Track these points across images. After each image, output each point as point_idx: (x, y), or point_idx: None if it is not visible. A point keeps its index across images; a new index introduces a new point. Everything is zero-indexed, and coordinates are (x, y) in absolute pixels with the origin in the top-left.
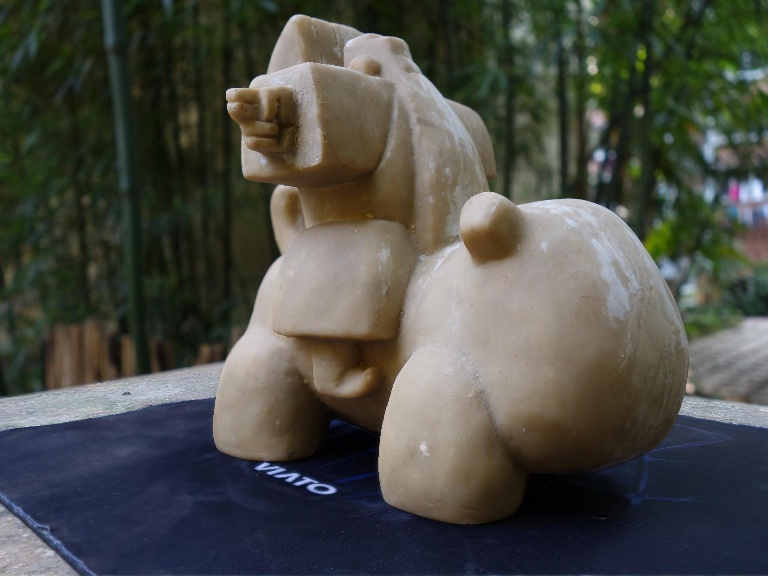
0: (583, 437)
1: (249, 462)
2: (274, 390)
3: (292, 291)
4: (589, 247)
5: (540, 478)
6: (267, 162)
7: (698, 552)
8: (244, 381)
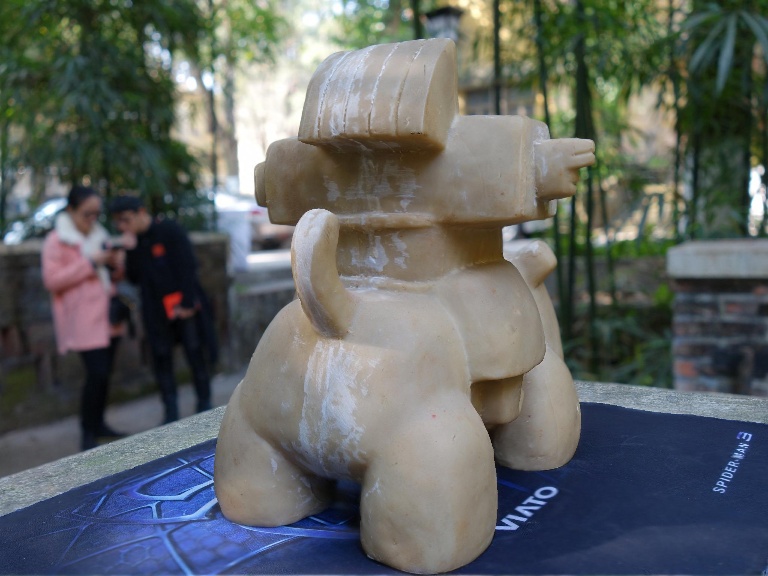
0: None
1: (498, 536)
2: None
3: None
4: None
5: None
6: None
7: None
8: (490, 449)
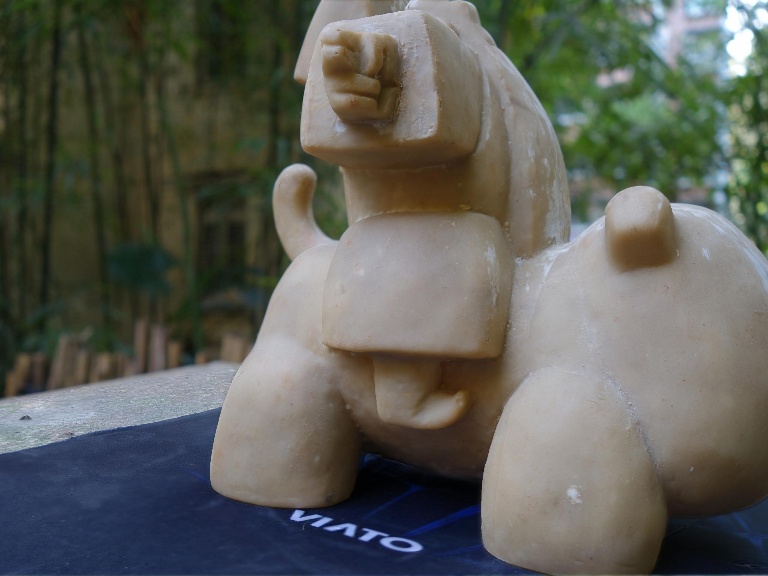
0: (752, 475)
1: (276, 510)
2: (313, 418)
3: (365, 295)
4: (745, 257)
5: (681, 522)
6: (346, 130)
7: None
8: (272, 407)
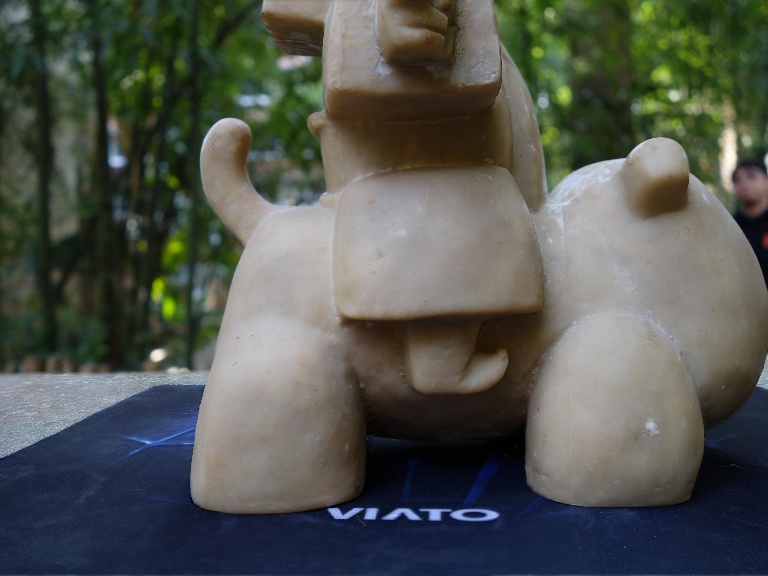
0: None
1: (307, 514)
2: (339, 402)
3: (413, 256)
4: None
5: None
6: (392, 72)
7: None
8: (293, 397)
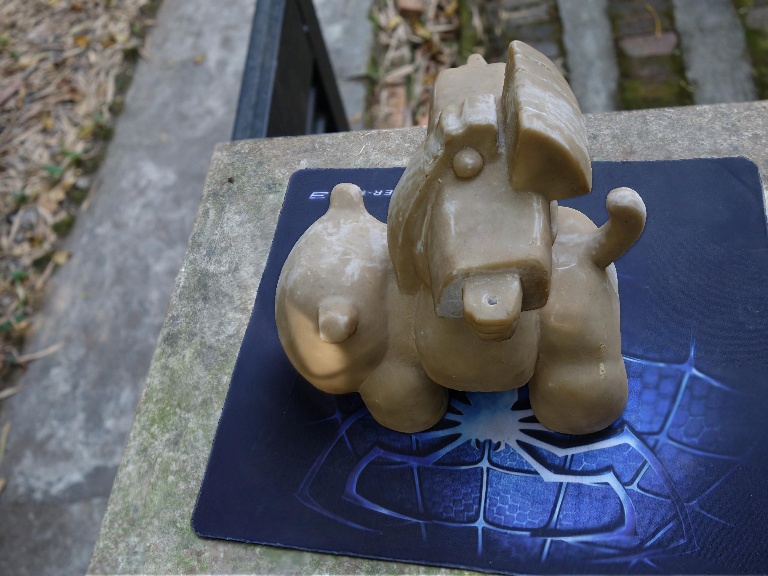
0: None
1: None
2: None
3: None
4: None
5: None
6: None
7: None
8: None
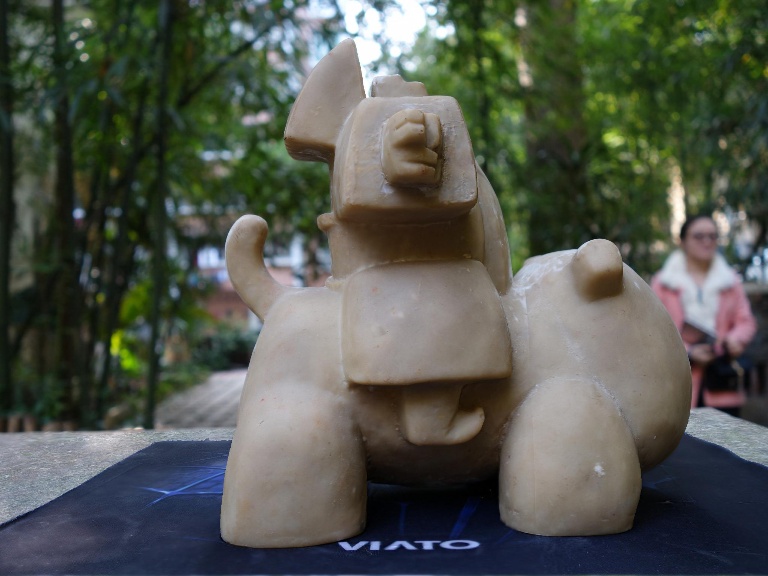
0: None
1: (322, 547)
2: (348, 453)
3: (409, 334)
4: None
5: None
6: (393, 192)
7: (753, 503)
8: (311, 448)
